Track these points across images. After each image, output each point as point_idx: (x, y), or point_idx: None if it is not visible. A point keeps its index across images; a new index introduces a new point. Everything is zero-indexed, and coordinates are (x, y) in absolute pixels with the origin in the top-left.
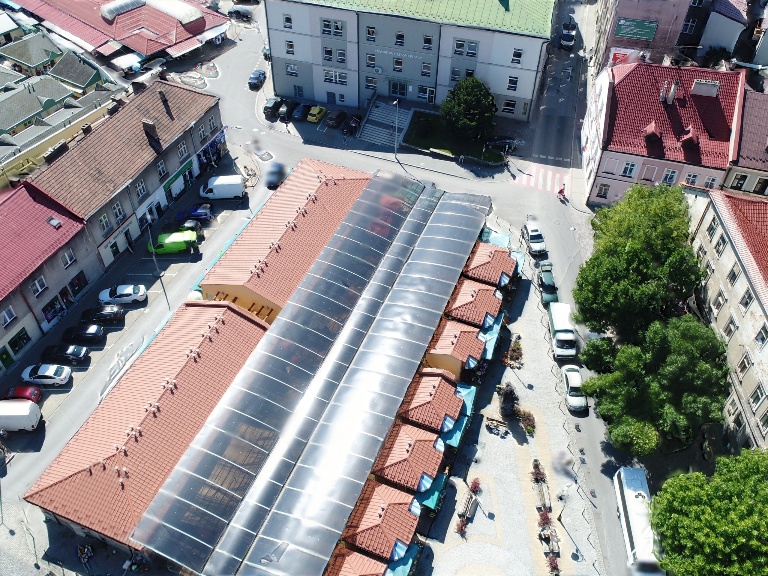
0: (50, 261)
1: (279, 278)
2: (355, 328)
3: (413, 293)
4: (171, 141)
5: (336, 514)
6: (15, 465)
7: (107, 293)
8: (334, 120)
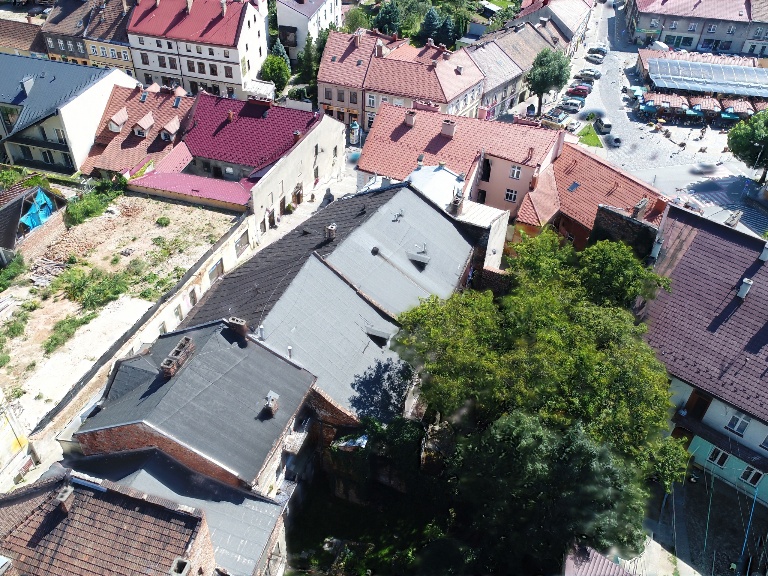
0: (725, 23)
1: None
2: None
3: None
4: None
5: None
6: None
7: (730, 54)
8: None
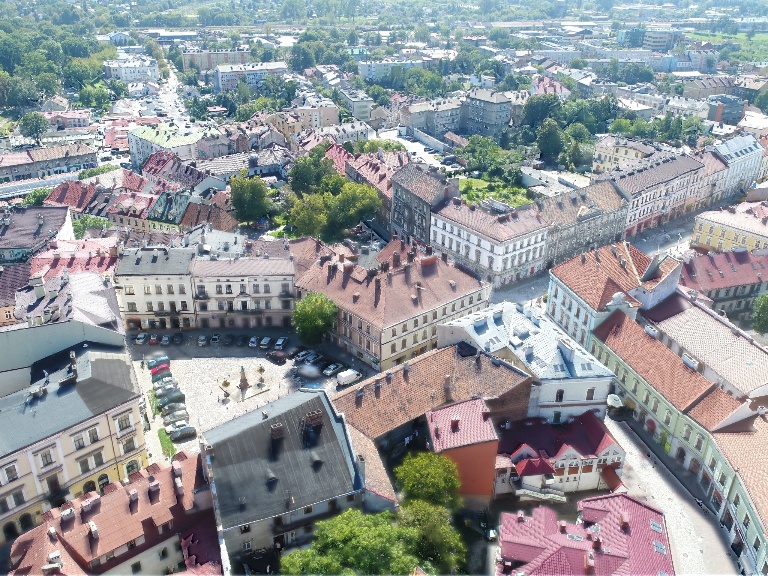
0: (22, 166)
1: None
2: (54, 185)
3: None
4: (72, 156)
5: None
6: None
7: None
8: (131, 168)
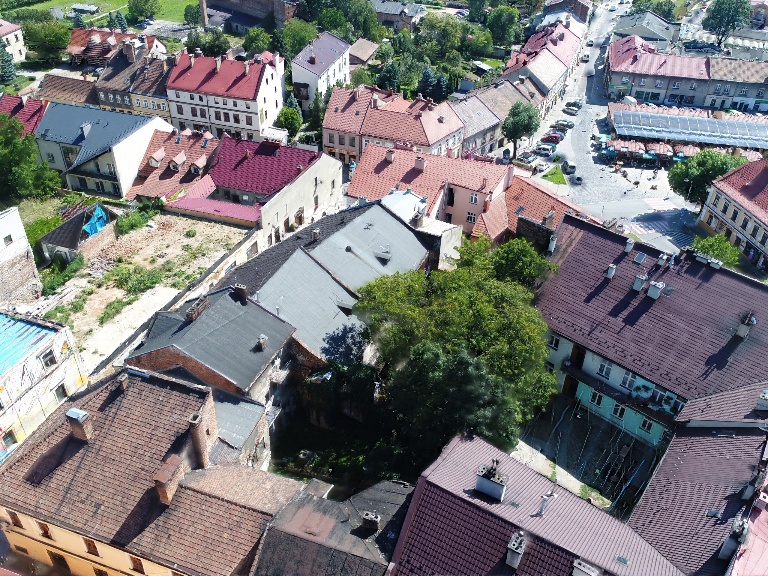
0: (687, 80)
1: None
2: None
3: None
4: None
5: (652, 135)
6: None
7: (693, 107)
8: None
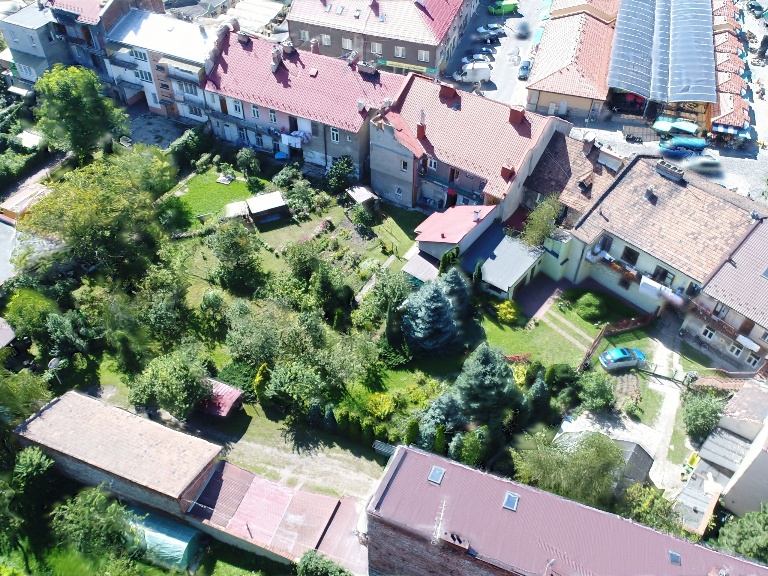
0: None
1: (601, 4)
2: (663, 20)
3: (688, 4)
4: None
5: (708, 75)
6: (488, 95)
7: (482, 29)
8: None
